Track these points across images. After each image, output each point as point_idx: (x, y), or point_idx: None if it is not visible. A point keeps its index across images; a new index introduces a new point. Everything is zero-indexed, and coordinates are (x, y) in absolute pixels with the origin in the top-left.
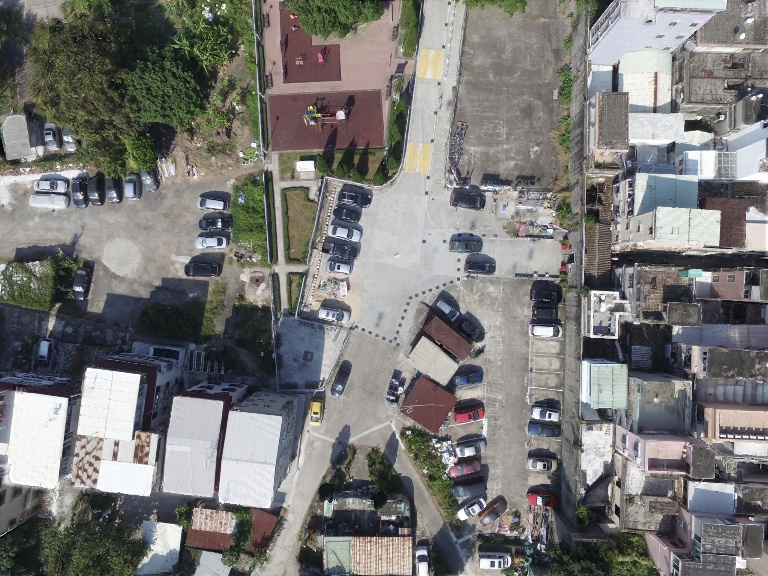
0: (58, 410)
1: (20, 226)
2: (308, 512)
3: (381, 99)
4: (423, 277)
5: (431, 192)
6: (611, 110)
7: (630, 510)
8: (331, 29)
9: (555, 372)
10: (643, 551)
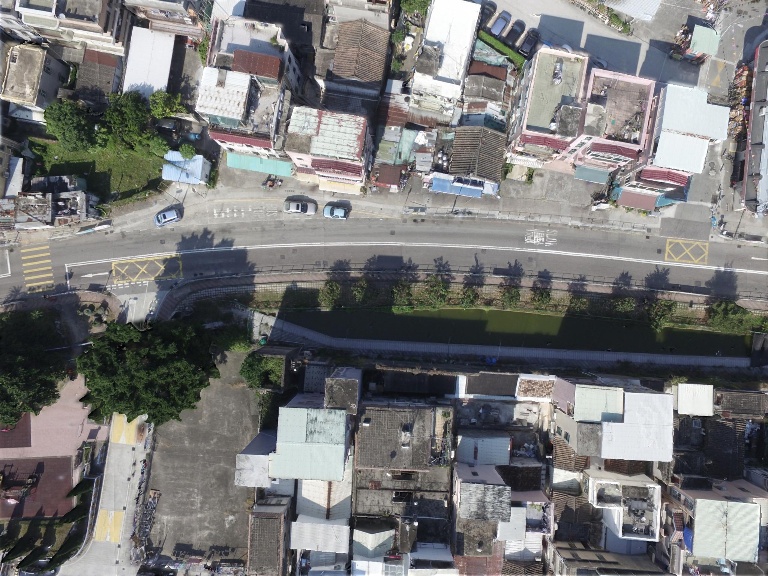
0: None
1: None
2: None
3: (72, 466)
4: None
5: (122, 561)
6: (262, 535)
7: None
8: None
9: None
10: None
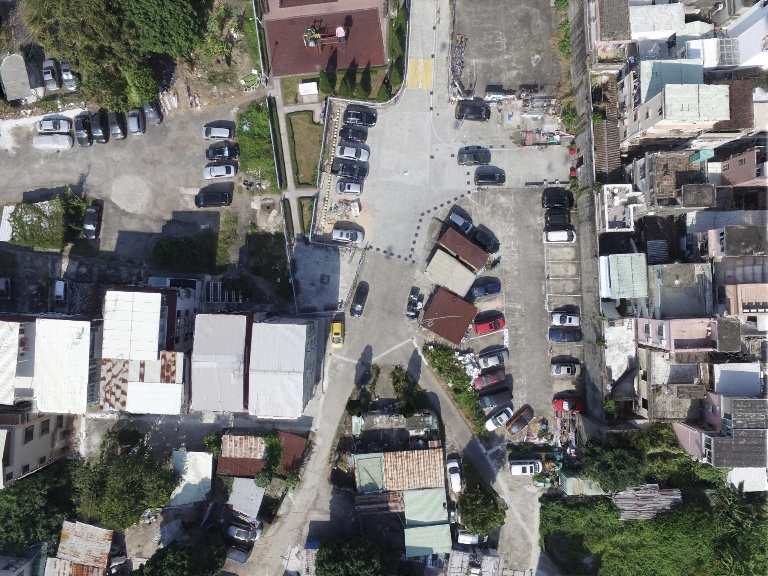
0: (81, 334)
1: (25, 170)
2: (336, 434)
3: (379, 17)
4: (434, 193)
5: (435, 107)
6: (611, 1)
7: (658, 400)
8: None
9: (572, 278)
10: (673, 442)
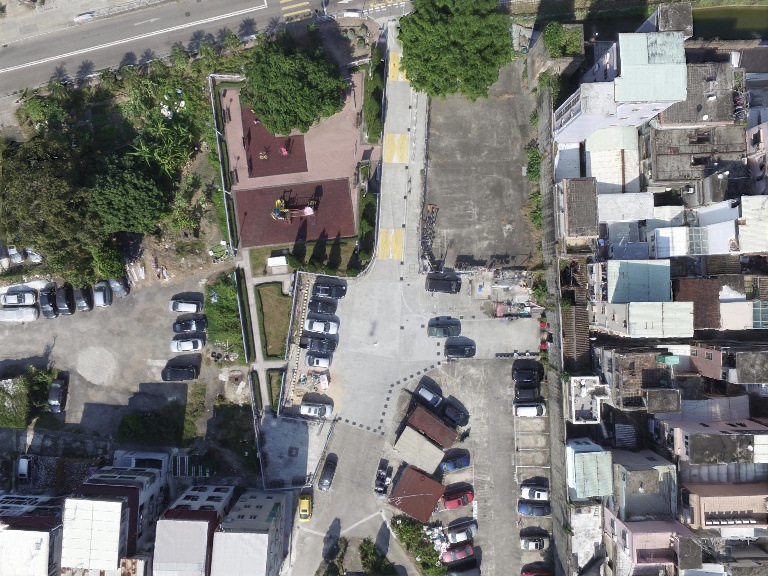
0: (40, 545)
1: None
2: None
3: (349, 187)
4: (403, 364)
5: (406, 277)
6: (579, 197)
7: None
8: (293, 126)
9: (541, 449)
10: None
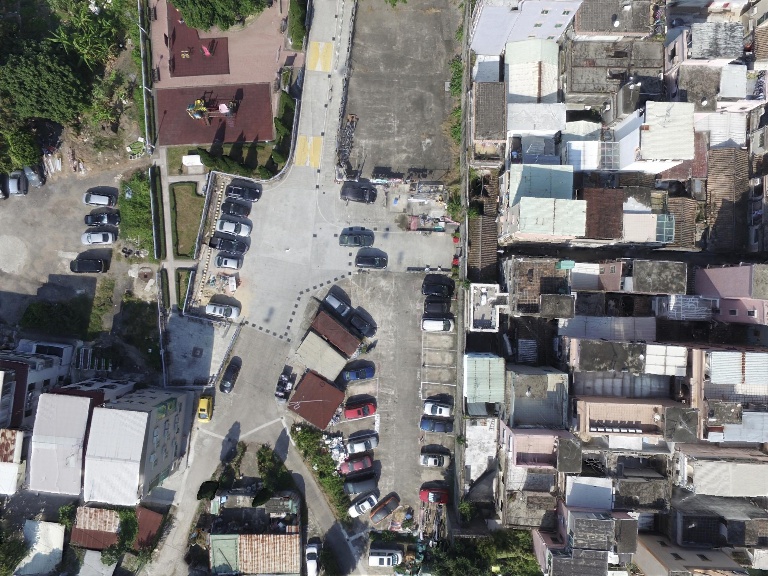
0: None
1: None
2: (198, 510)
3: (270, 92)
4: (314, 272)
5: (322, 186)
6: (487, 100)
7: (512, 506)
8: (211, 21)
9: (448, 367)
10: (528, 547)
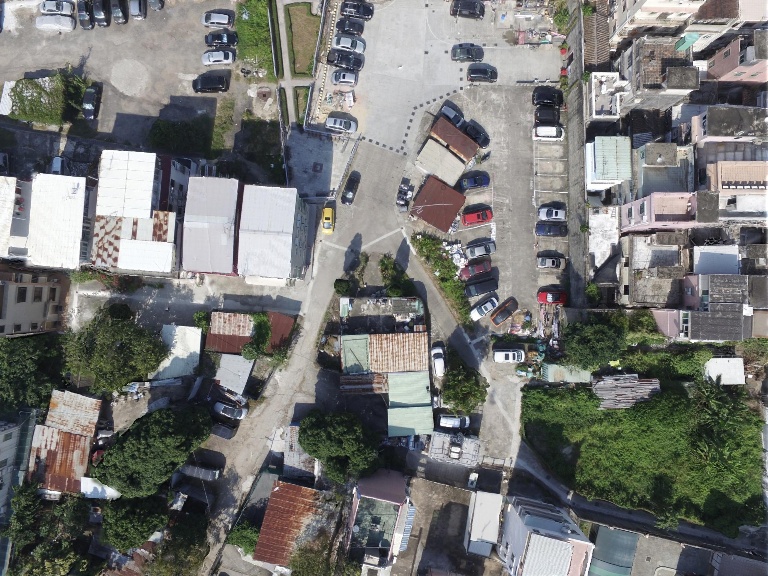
0: (76, 190)
1: (27, 50)
2: (324, 319)
3: None
4: (427, 87)
5: (431, 4)
6: None
7: (638, 284)
8: None
9: (559, 175)
10: (653, 328)
